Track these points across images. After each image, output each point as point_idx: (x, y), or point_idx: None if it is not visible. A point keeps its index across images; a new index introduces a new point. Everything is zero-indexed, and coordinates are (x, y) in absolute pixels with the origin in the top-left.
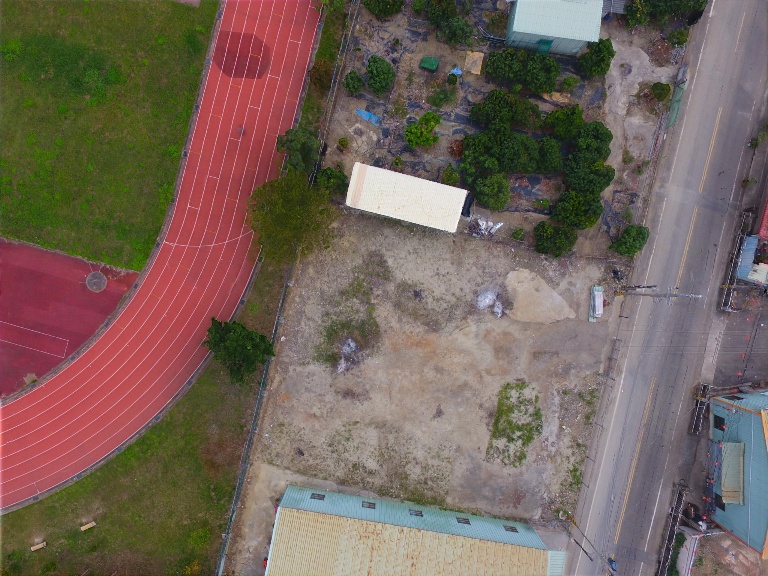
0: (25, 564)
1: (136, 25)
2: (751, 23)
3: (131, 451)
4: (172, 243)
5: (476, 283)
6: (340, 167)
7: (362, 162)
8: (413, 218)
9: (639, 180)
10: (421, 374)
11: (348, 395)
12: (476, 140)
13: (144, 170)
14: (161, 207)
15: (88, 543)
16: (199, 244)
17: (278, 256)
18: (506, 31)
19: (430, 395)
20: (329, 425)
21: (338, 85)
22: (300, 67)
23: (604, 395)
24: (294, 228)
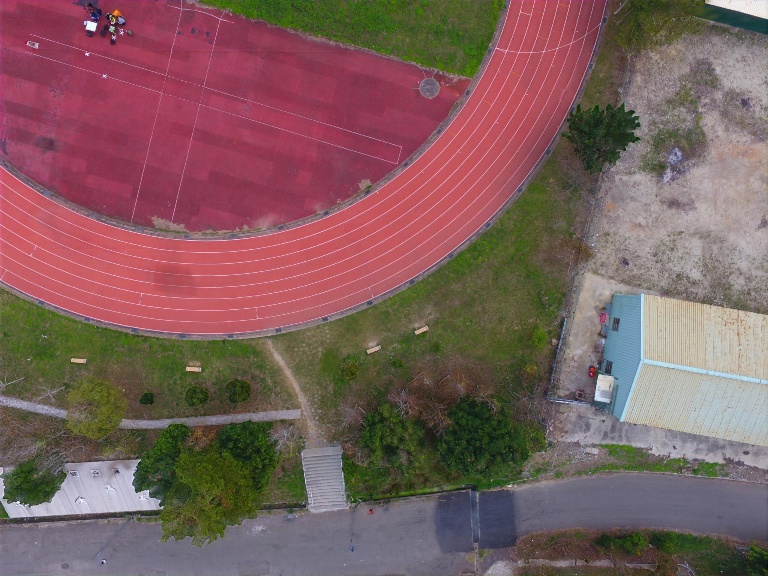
0: (360, 367)
1: None
2: None
3: (463, 257)
4: (504, 49)
5: None
6: None
7: None
8: (764, 13)
9: None
10: (747, 184)
11: (674, 205)
12: None
13: None
14: (494, 13)
15: (421, 347)
16: (530, 50)
17: (609, 63)
18: None
19: (755, 205)
20: (654, 235)
21: None
22: None
23: None
24: (678, 4)
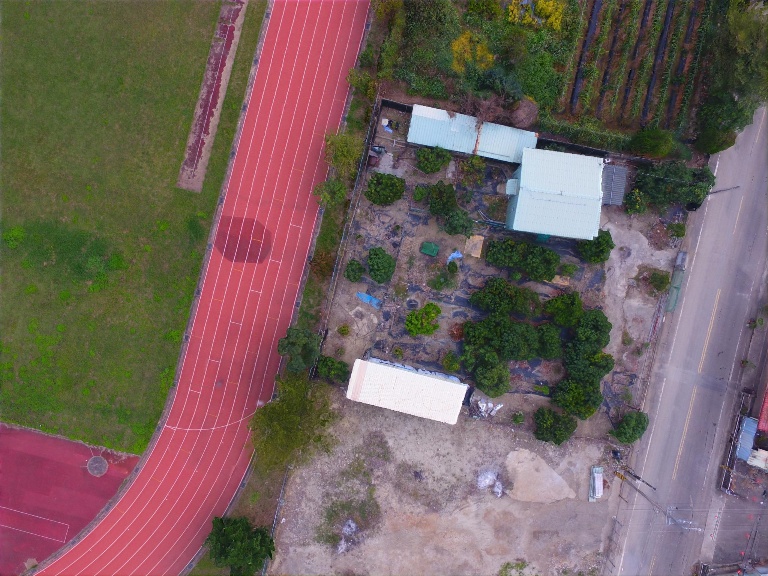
0: None
1: (138, 211)
2: (749, 206)
3: None
4: (173, 427)
5: (476, 463)
6: (341, 354)
7: (363, 358)
8: (413, 411)
9: (638, 361)
10: (421, 554)
11: (348, 575)
12: (476, 332)
13: (145, 355)
14: (162, 391)
15: None
16: (200, 428)
17: None
18: (506, 215)
19: (430, 575)
20: None
21: (339, 272)
22: (301, 251)
23: (604, 574)
24: None
